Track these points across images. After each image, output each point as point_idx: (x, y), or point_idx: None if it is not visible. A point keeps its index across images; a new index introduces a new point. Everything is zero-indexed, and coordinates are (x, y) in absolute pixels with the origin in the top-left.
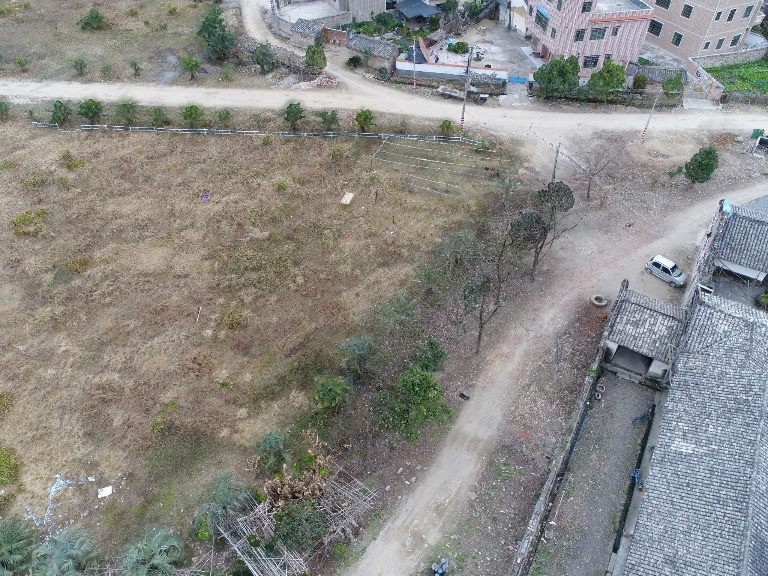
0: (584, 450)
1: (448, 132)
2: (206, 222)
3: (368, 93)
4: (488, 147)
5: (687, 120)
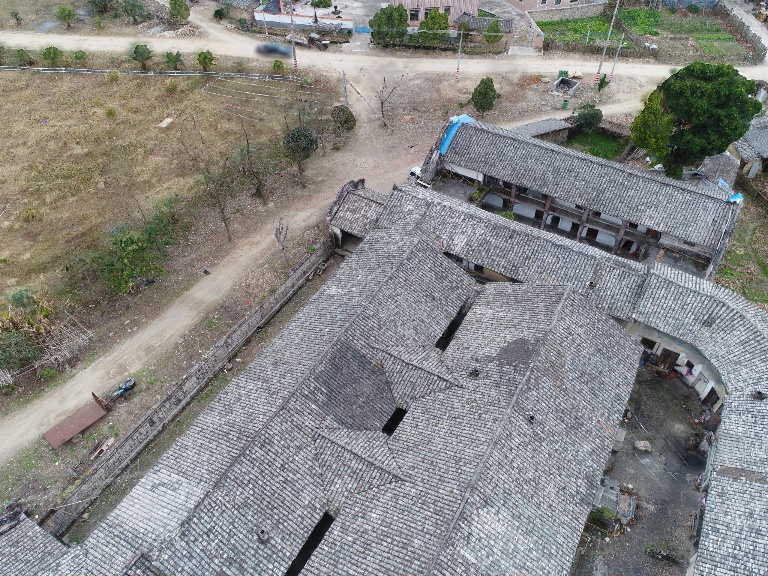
0: (290, 310)
1: (279, 71)
2: (37, 141)
3: (224, 40)
4: (311, 83)
5: (506, 64)
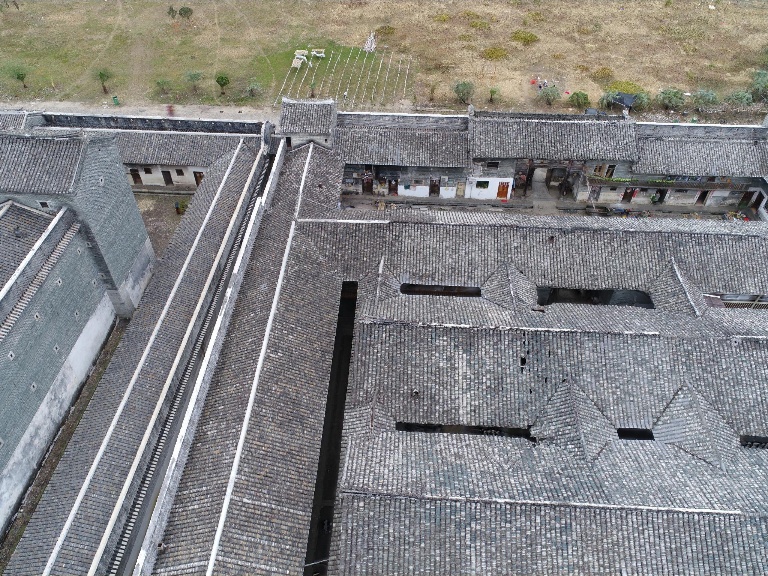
0: None
1: None
2: None
3: None
4: None
5: None
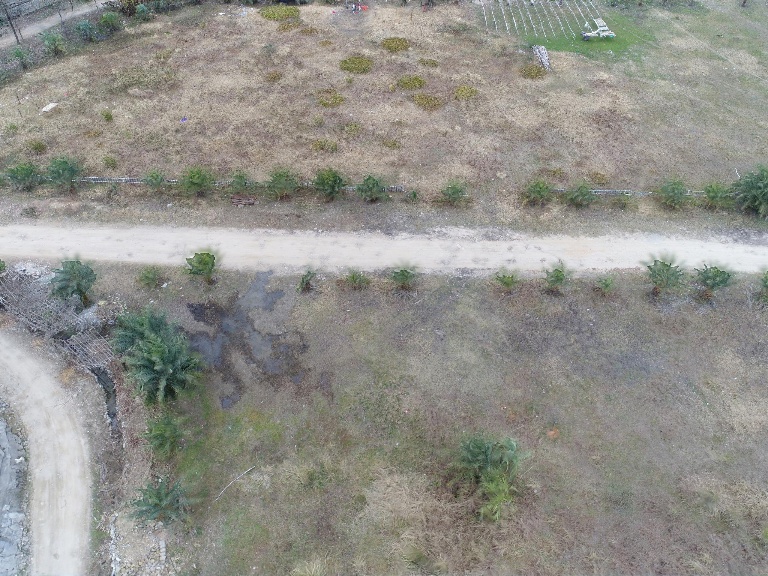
0: None
1: None
2: None
3: None
4: None
5: None
